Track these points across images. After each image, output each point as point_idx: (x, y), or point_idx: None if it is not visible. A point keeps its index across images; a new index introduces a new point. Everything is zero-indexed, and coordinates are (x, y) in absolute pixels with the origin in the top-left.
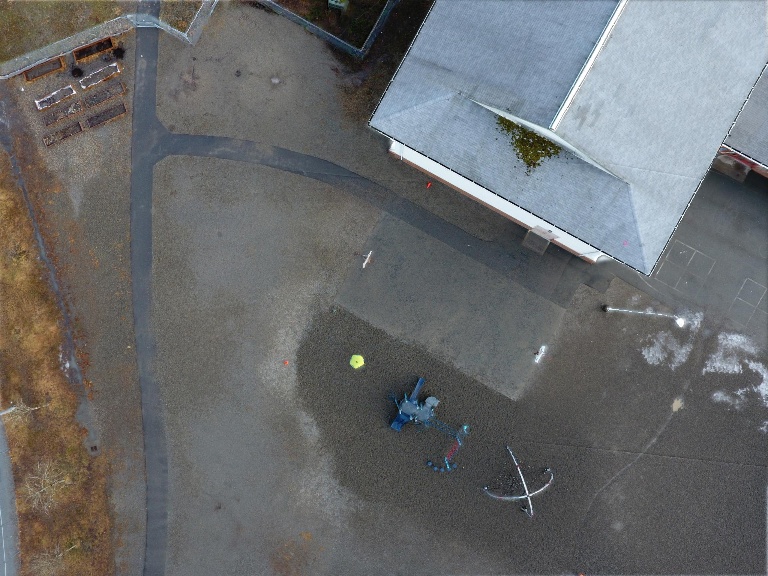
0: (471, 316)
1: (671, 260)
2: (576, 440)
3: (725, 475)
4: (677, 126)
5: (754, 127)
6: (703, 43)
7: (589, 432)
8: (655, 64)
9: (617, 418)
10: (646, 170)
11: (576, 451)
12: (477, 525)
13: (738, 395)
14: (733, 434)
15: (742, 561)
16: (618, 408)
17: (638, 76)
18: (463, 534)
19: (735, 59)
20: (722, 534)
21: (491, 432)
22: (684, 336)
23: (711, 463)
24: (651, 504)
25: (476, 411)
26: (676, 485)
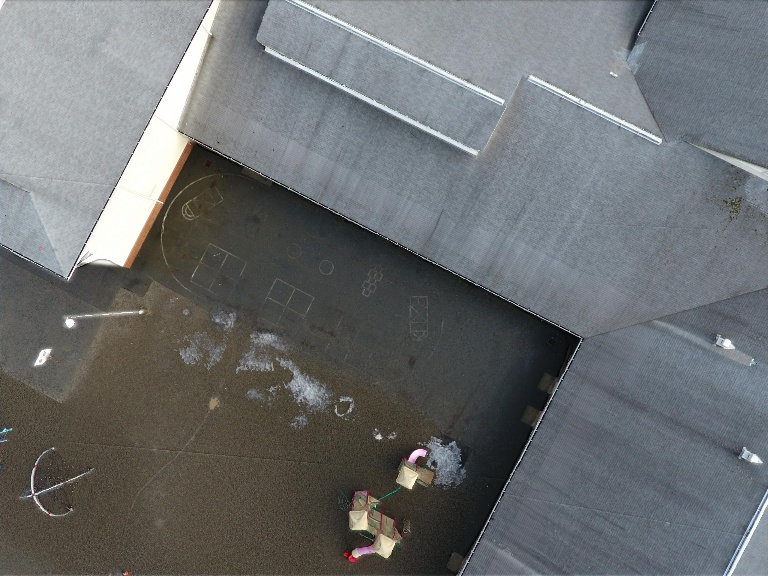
0: (19, 322)
1: (205, 263)
2: (118, 440)
3: (258, 471)
4: (77, 136)
5: (236, 134)
6: (94, 57)
7: (130, 432)
8: (39, 79)
9: (157, 417)
10: (47, 179)
11: (118, 450)
12: (25, 525)
13: (270, 392)
14: (265, 430)
15: (275, 555)
16: (157, 407)
17: (21, 91)
18: (12, 534)
19: (135, 71)
20: (256, 529)
21: (38, 434)
22: (218, 336)
23: (245, 459)
24: (189, 501)
25: (24, 414)
26: (212, 481)
